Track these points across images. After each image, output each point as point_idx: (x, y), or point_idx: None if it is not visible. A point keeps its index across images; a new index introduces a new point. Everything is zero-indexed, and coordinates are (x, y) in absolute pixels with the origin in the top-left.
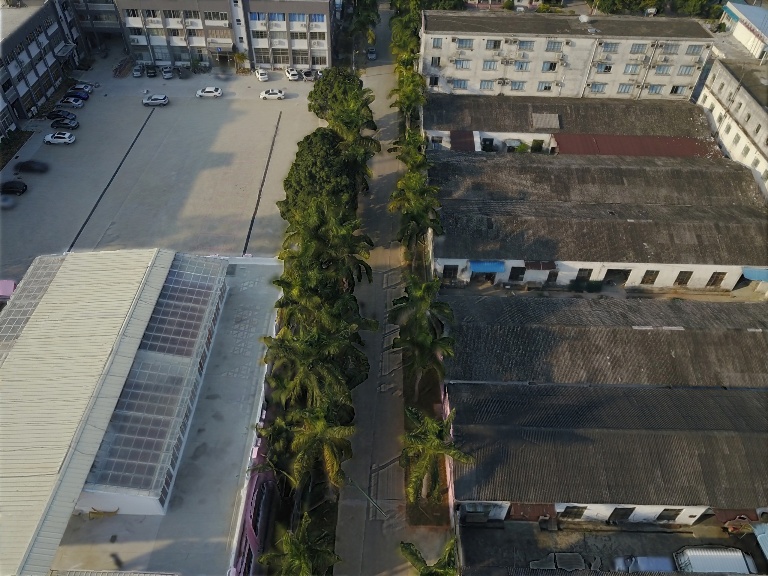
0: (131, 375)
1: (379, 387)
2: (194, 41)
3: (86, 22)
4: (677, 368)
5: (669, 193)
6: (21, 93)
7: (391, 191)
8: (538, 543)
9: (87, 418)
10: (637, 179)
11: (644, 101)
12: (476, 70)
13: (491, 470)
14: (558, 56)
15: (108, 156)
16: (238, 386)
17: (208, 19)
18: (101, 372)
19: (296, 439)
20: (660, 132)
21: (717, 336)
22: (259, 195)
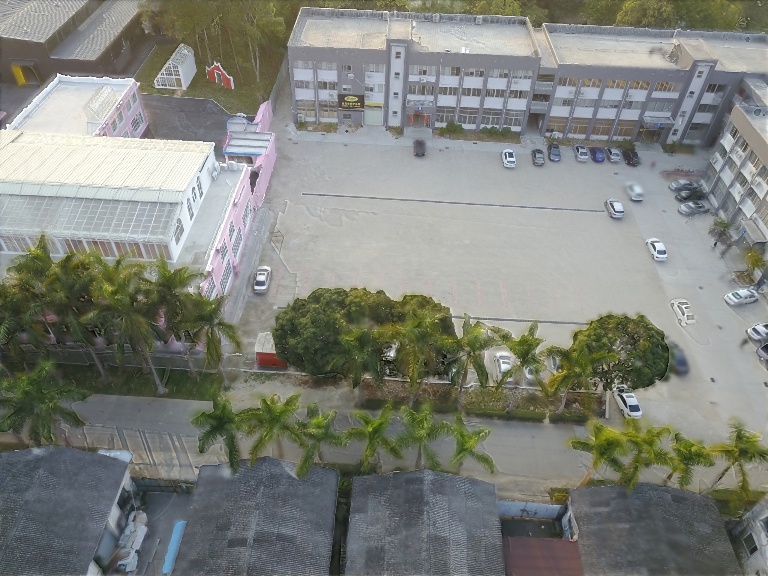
0: (41, 198)
1: None
2: (747, 205)
3: None
4: None
5: None
6: (555, 114)
7: (442, 459)
8: None
9: (5, 182)
10: None
11: None
12: None
13: None
14: None
15: (492, 194)
16: None
17: None
18: (46, 182)
19: None
20: None
21: None
22: None
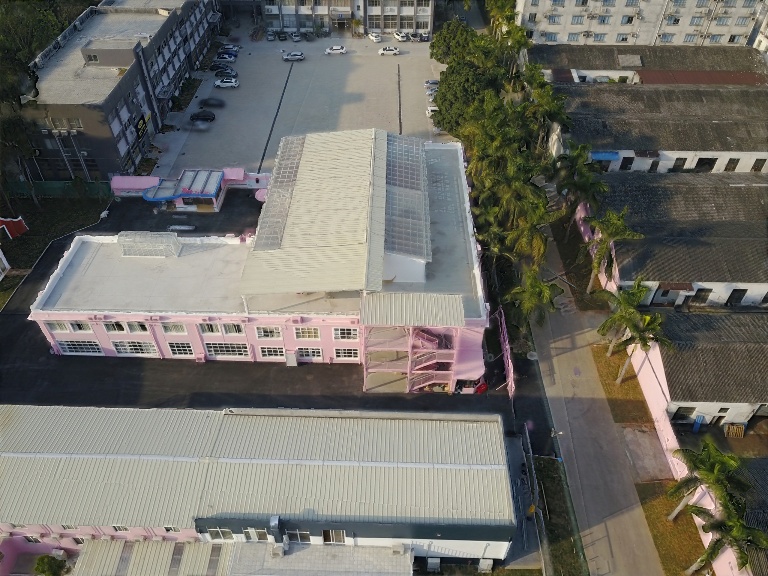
0: (387, 197)
1: None
2: (318, 10)
3: None
4: (766, 211)
5: (740, 107)
6: (192, 48)
7: None
8: None
9: (371, 217)
10: (713, 98)
11: (708, 46)
12: (566, 24)
13: (644, 262)
14: (635, 10)
15: (268, 96)
16: (449, 217)
17: None
18: (368, 194)
19: (510, 235)
20: (725, 68)
21: None
22: (400, 121)
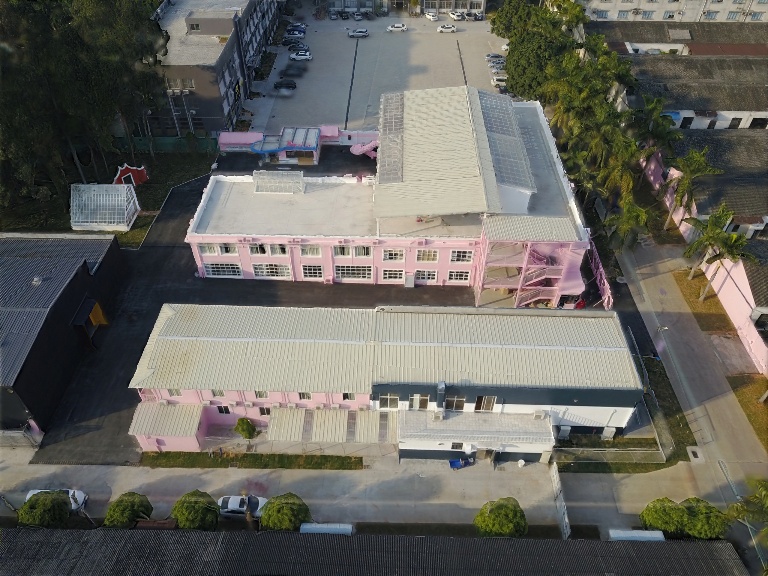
0: (489, 141)
1: None
2: None
3: None
4: None
5: None
6: (267, 24)
7: None
8: None
9: (479, 156)
10: (762, 66)
11: (752, 22)
12: (616, 2)
13: (718, 199)
14: None
15: (341, 68)
16: (539, 162)
17: None
18: (473, 138)
19: (601, 173)
20: None
21: None
22: None
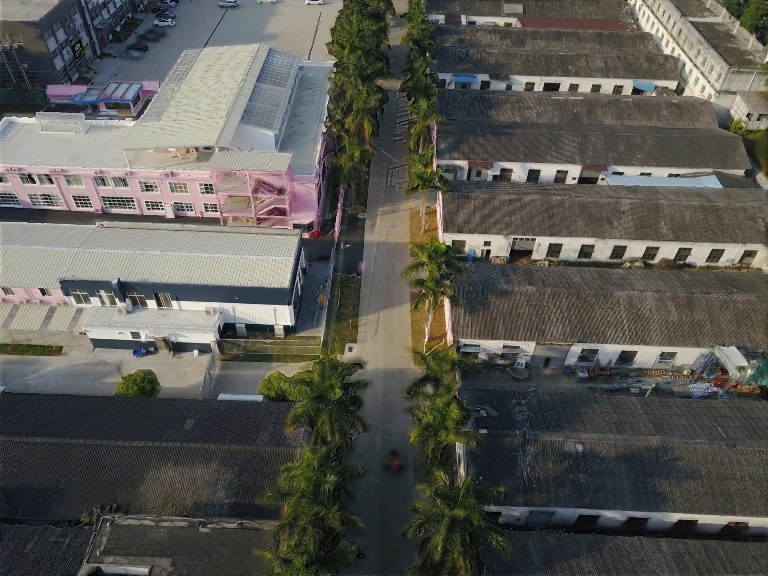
0: (254, 90)
1: (393, 138)
2: None
3: None
4: (577, 117)
5: (593, 46)
6: None
7: (402, 53)
8: None
9: (235, 101)
10: (572, 37)
11: None
12: None
13: (458, 146)
14: None
15: (199, 34)
16: (311, 112)
17: None
18: (238, 86)
19: (348, 120)
20: (595, 17)
21: (603, 102)
22: (309, 56)
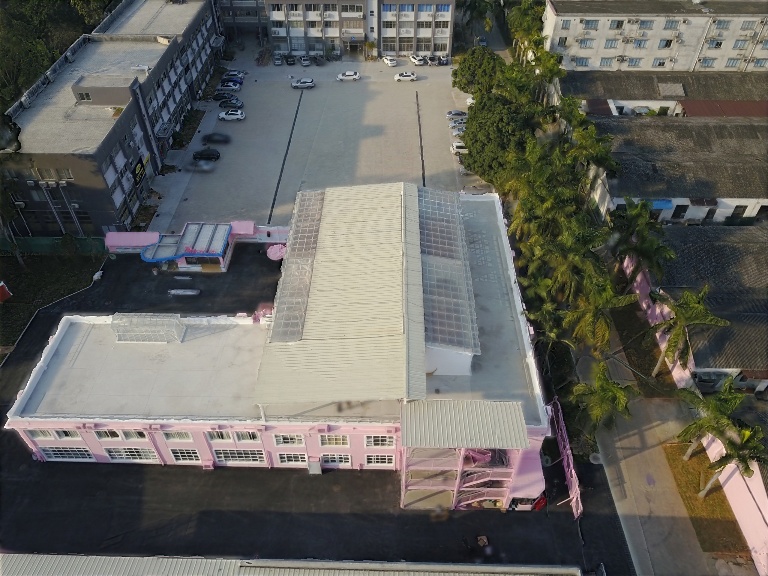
0: (423, 271)
1: None
2: (329, 32)
3: (228, 18)
4: None
5: None
6: (193, 77)
7: None
8: (758, 409)
9: (407, 298)
10: None
11: (755, 72)
12: (598, 49)
13: (722, 345)
14: (675, 34)
15: (277, 129)
16: (492, 288)
17: (345, 11)
18: (402, 268)
19: (568, 317)
20: None
21: None
22: (422, 158)
